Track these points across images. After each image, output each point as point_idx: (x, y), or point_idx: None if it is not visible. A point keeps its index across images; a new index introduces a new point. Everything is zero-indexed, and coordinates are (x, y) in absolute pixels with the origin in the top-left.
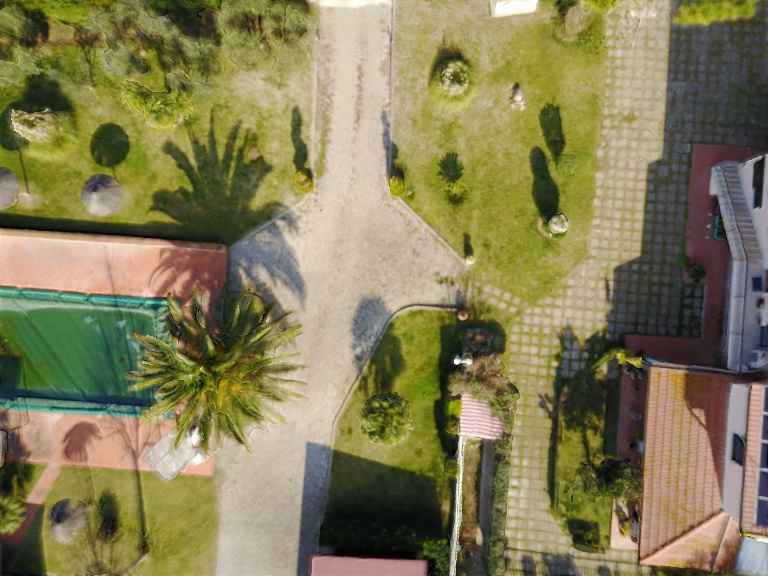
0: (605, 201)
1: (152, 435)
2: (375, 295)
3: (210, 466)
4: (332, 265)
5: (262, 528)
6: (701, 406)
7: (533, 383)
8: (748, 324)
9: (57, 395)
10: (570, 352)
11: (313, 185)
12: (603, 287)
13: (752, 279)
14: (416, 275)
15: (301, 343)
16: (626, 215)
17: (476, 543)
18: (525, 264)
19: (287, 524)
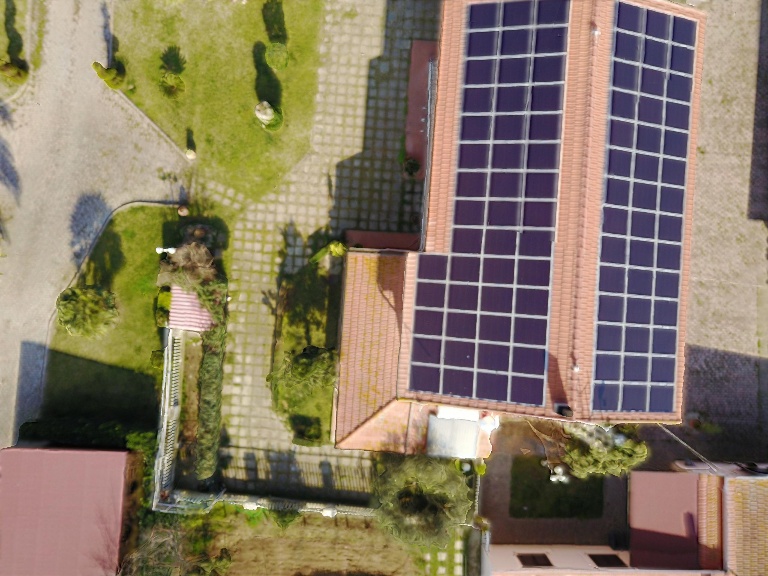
0: (328, 96)
1: None
2: (95, 191)
3: None
4: (50, 160)
5: None
6: (391, 288)
7: (256, 280)
8: None
9: None
10: (293, 248)
11: (27, 77)
12: (326, 183)
13: None
14: (138, 171)
15: (16, 240)
16: (349, 111)
17: None
18: (248, 160)
19: None
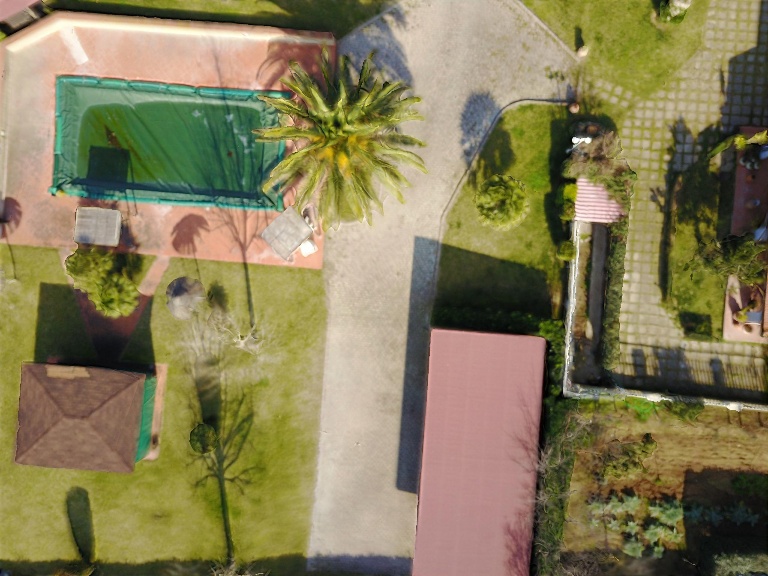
0: None
1: (260, 228)
2: (484, 90)
3: (318, 259)
4: (440, 60)
5: (370, 322)
6: None
7: (644, 177)
8: None
9: (165, 188)
10: (683, 146)
11: None
12: (718, 79)
13: None
14: (525, 70)
15: None
16: (742, 5)
17: (586, 337)
18: (637, 57)
19: (395, 318)
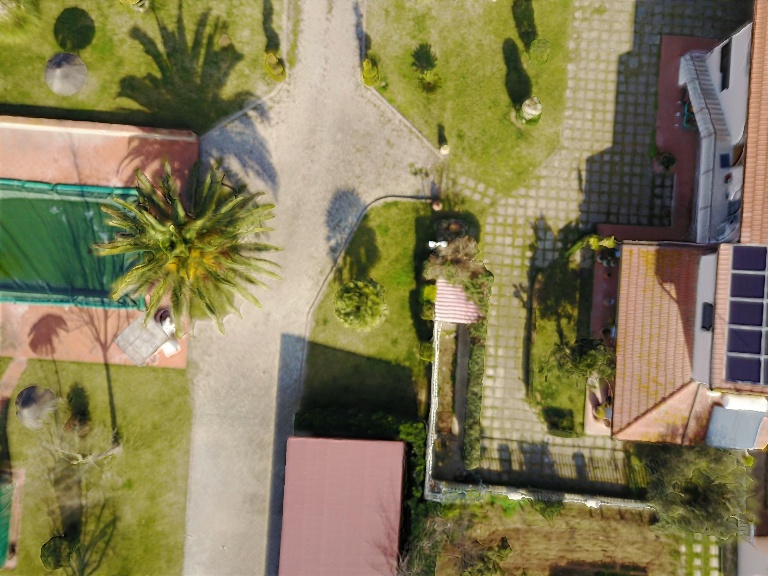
0: (577, 92)
1: (121, 328)
2: (349, 186)
3: (182, 359)
4: (305, 156)
5: (235, 421)
6: (671, 280)
7: (507, 273)
8: (716, 199)
9: (21, 288)
10: (544, 242)
11: (286, 75)
12: (576, 177)
13: (720, 156)
14: (390, 166)
15: (274, 235)
16: (598, 106)
17: (452, 432)
18: (499, 155)
19: (261, 417)
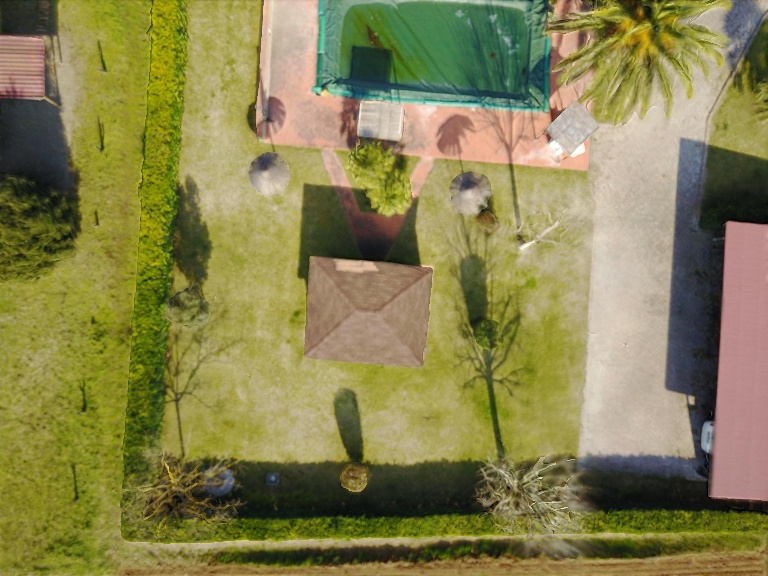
0: None
1: (526, 129)
2: None
3: (585, 160)
4: None
5: (636, 223)
6: None
7: None
8: None
9: (429, 89)
10: None
11: None
12: None
13: None
14: None
15: None
16: None
17: None
18: None
19: (661, 219)
